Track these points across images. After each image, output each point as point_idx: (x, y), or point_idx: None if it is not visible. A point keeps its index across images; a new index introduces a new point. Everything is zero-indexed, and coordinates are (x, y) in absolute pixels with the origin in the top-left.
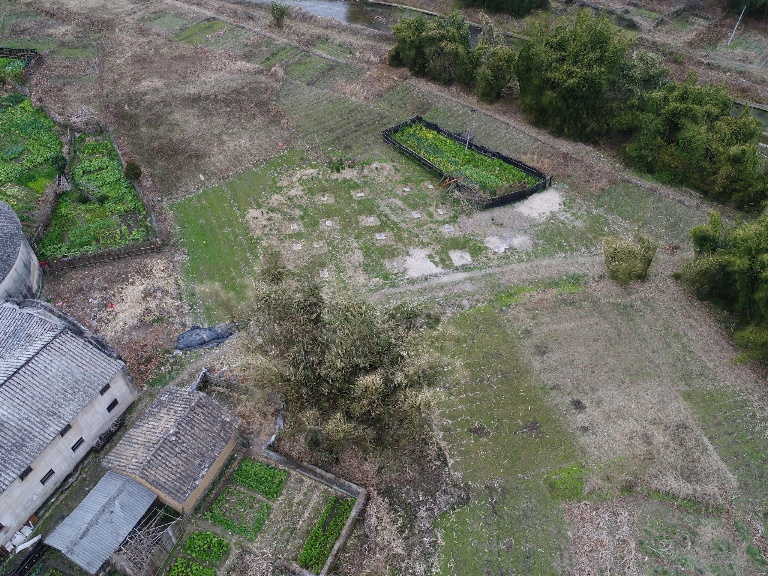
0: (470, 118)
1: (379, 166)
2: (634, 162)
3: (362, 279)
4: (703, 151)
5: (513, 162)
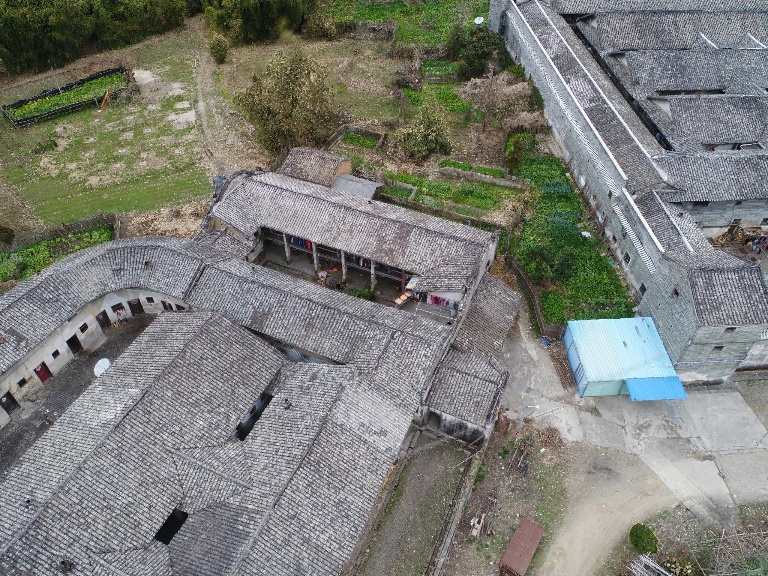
0: (7, 96)
1: (62, 127)
2: (117, 43)
3: (190, 136)
4: (140, 10)
5: (94, 76)
